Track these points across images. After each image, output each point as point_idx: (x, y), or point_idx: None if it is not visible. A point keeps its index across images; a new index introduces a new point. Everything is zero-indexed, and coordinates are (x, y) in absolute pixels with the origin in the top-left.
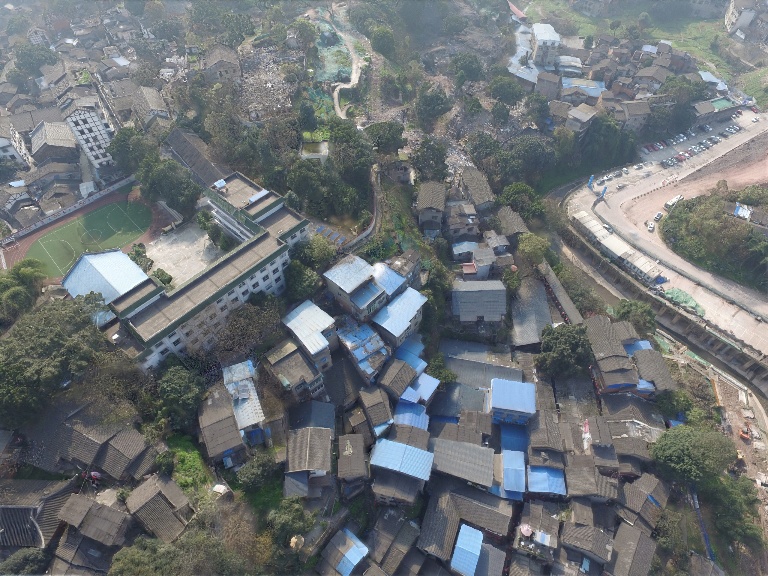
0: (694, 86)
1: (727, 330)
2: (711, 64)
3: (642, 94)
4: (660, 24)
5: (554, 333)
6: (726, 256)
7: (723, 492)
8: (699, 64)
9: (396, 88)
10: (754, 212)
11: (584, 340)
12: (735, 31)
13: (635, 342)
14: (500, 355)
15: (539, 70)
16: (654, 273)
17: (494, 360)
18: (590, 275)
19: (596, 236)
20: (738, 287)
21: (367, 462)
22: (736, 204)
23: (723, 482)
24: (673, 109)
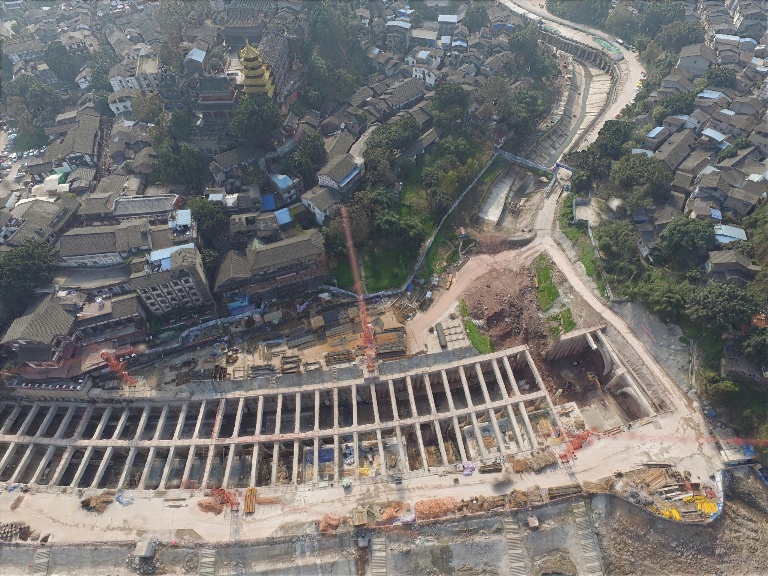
0: None
1: (570, 38)
2: None
3: None
4: None
5: (470, 7)
6: (577, 11)
7: (538, 57)
8: None
9: None
10: None
11: (483, 6)
12: None
13: None
14: None
15: None
16: (537, 19)
17: None
18: None
19: (509, 7)
20: (582, 25)
21: (384, 27)
22: None
23: None
24: None
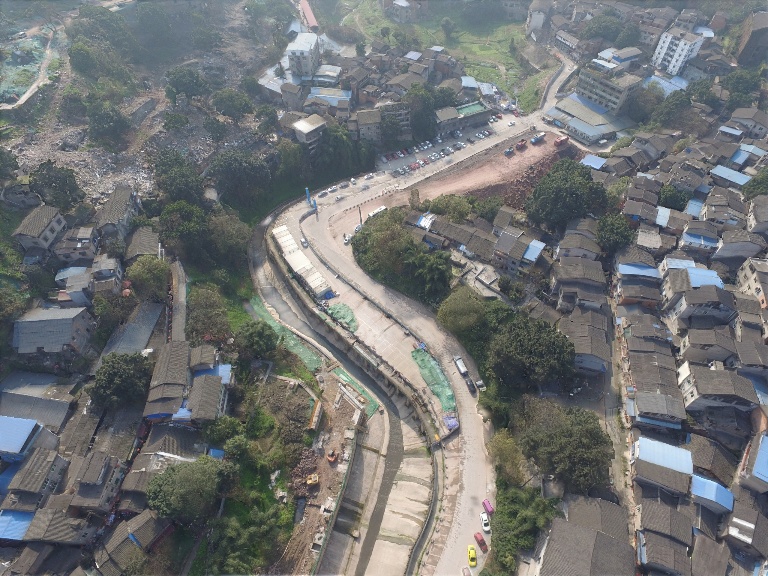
0: (438, 92)
1: (370, 346)
2: (502, 67)
3: (382, 102)
4: (473, 28)
5: (104, 363)
6: None
7: (222, 526)
8: (492, 68)
9: (83, 106)
10: (435, 222)
11: (123, 370)
12: (530, 33)
13: (216, 366)
14: (62, 387)
15: (294, 80)
16: (321, 288)
17: (50, 393)
18: (279, 291)
19: (283, 251)
20: (405, 300)
21: None
22: (423, 214)
23: (280, 510)
24: (413, 116)
